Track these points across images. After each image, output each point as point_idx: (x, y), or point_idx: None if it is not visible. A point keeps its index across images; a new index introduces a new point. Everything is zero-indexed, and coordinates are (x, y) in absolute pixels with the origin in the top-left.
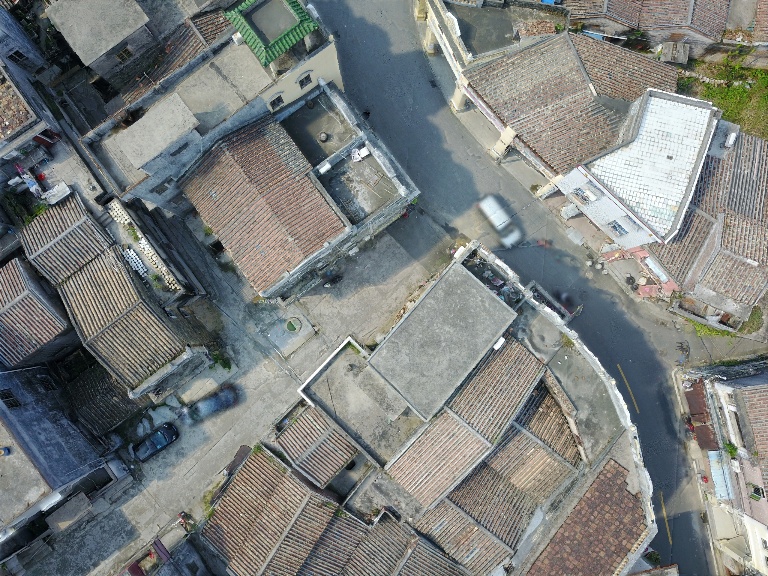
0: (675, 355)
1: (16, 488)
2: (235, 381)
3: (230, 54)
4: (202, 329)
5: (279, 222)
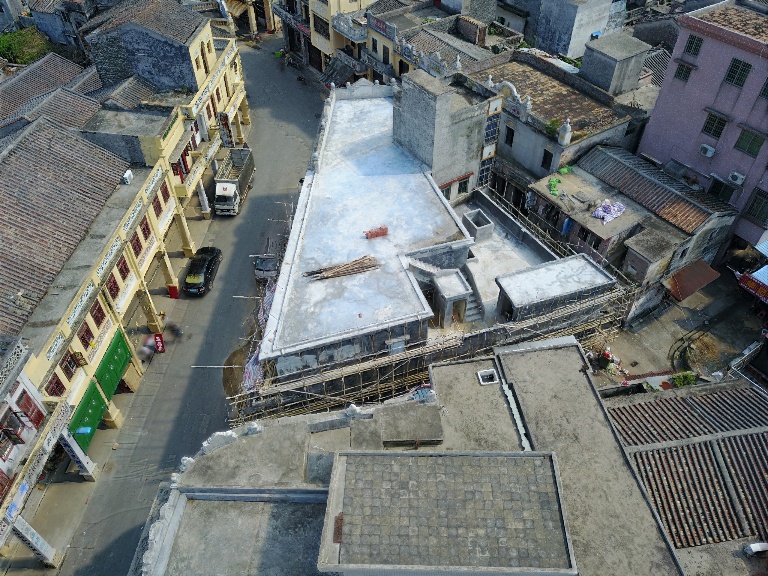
0: None
1: None
2: None
3: None
4: None
5: None
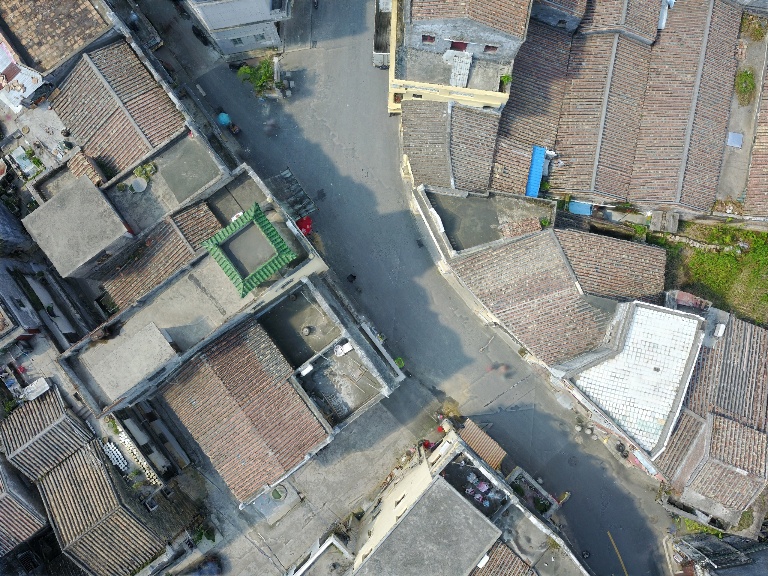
0: (666, 522)
1: None
2: (220, 550)
3: (209, 265)
4: (186, 503)
5: (259, 435)
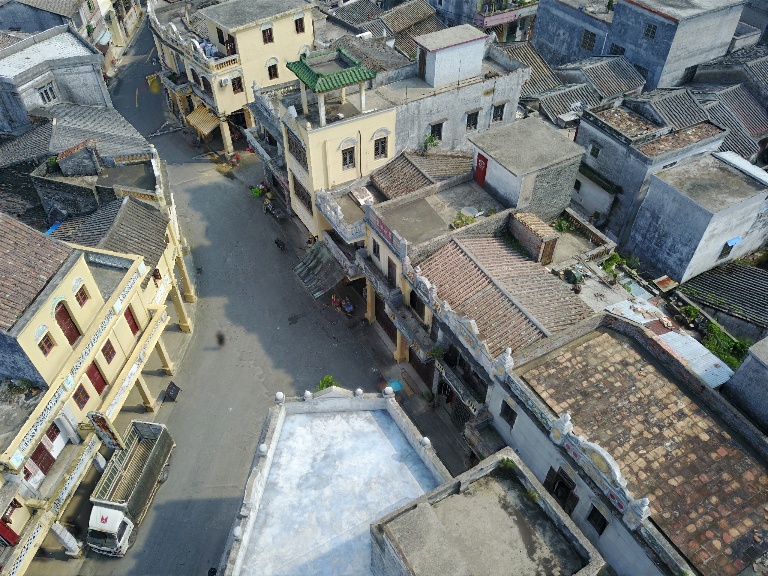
0: None
1: (569, 2)
2: None
3: None
4: None
5: None
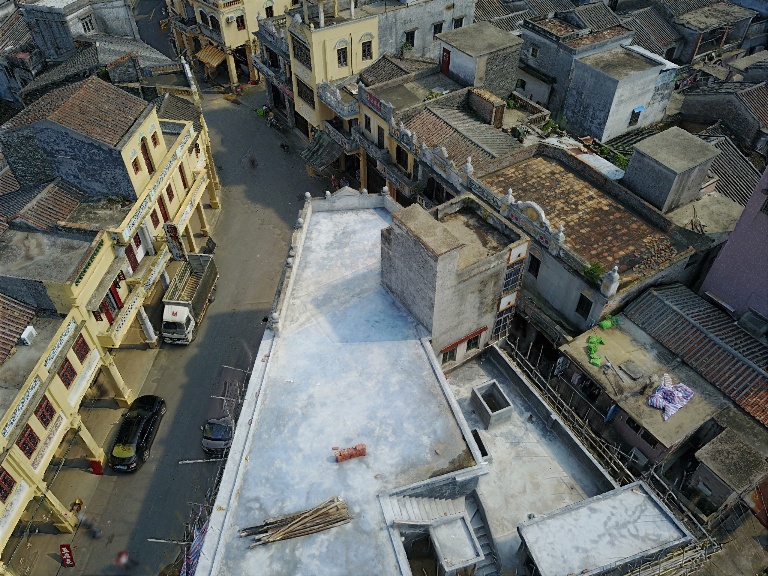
0: None
1: None
2: None
3: None
4: None
5: None
